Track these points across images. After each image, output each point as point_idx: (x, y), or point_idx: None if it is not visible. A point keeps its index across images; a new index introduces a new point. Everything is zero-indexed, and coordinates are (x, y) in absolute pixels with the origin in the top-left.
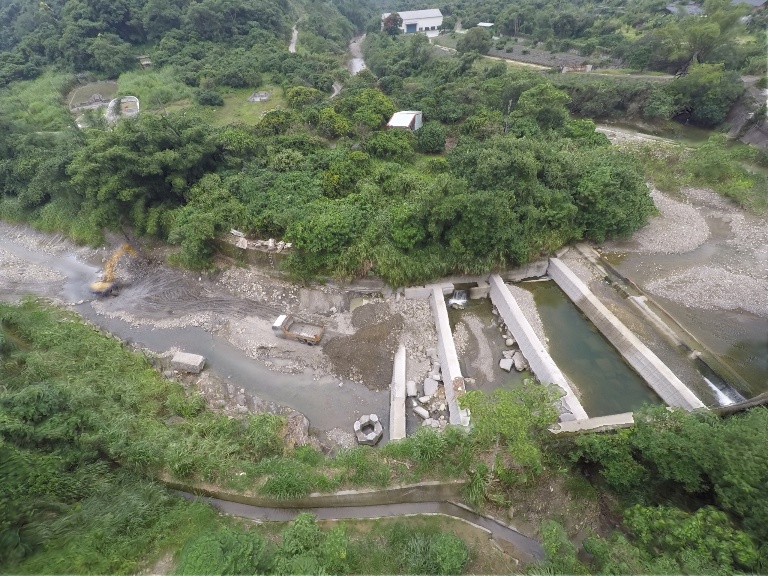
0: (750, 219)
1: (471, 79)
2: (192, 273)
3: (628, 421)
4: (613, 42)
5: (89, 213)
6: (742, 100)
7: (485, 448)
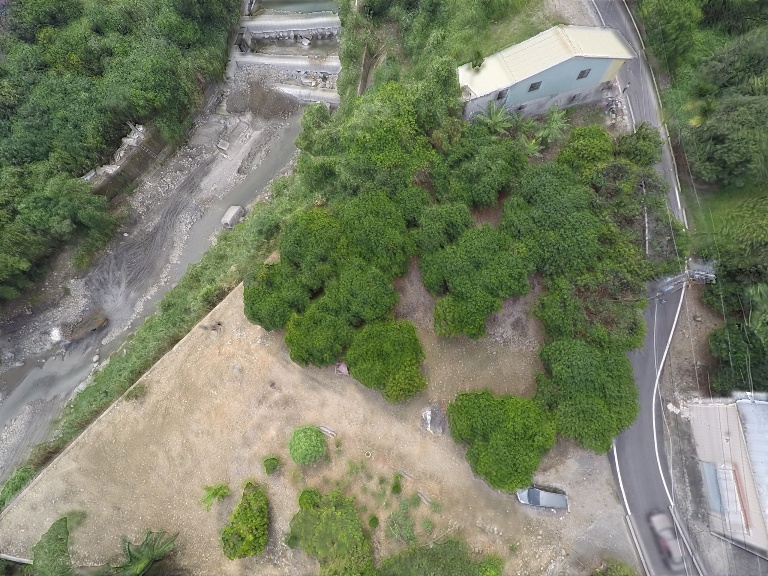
0: None
1: None
2: (113, 242)
3: None
4: None
5: None
6: None
7: (356, 30)
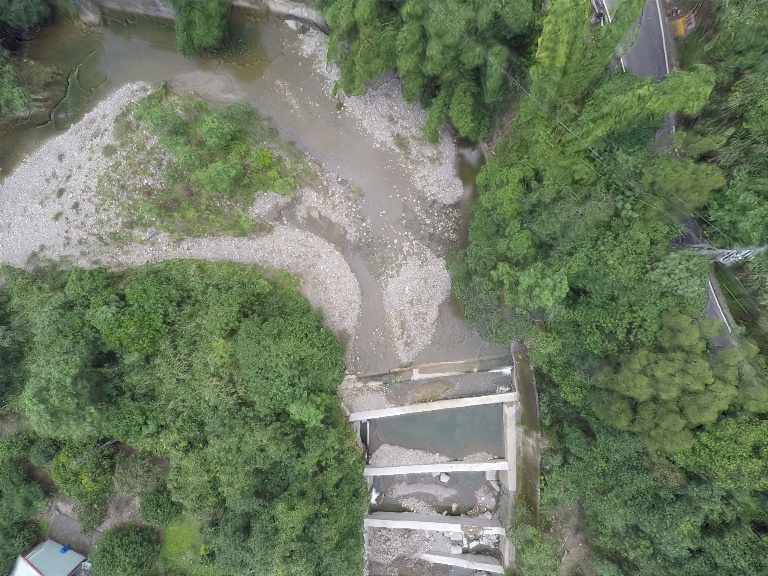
0: (316, 187)
1: None
2: None
3: (513, 440)
4: None
5: None
6: None
7: None
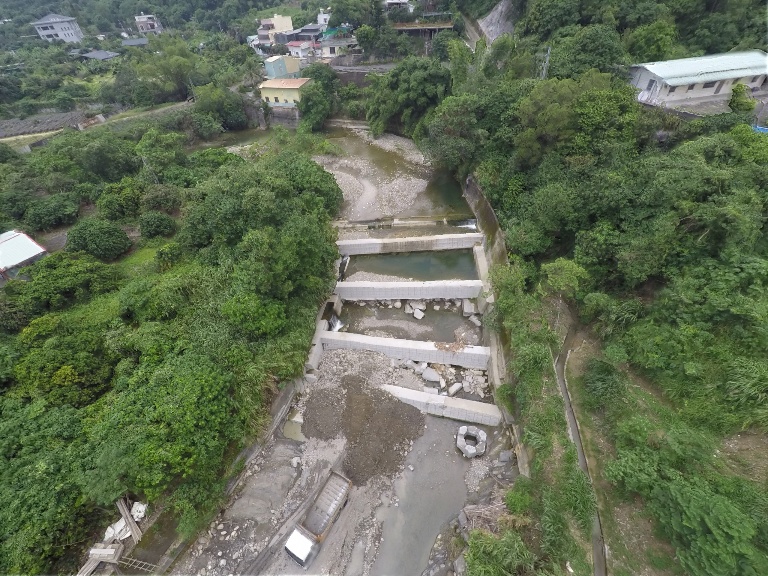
0: (348, 159)
1: (1, 170)
2: None
3: (484, 265)
4: (80, 92)
5: None
6: (245, 103)
7: None
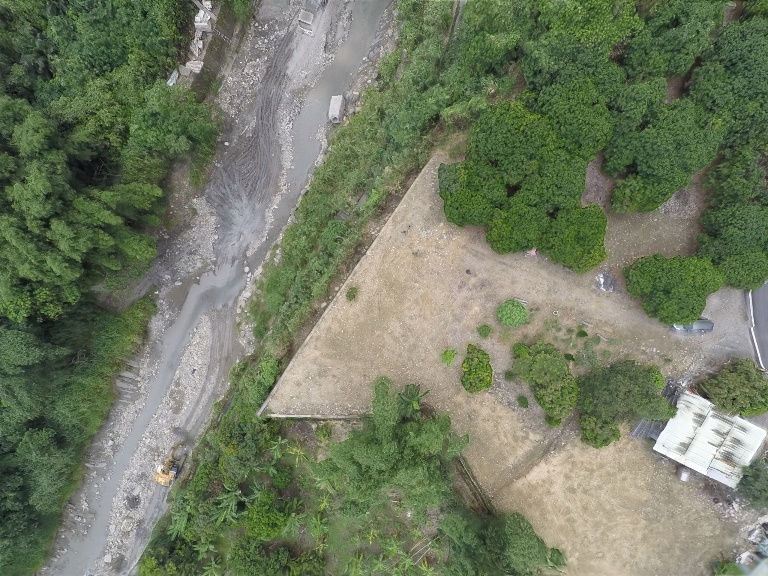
0: None
1: None
2: (217, 154)
3: None
4: None
5: (119, 278)
6: None
7: None
